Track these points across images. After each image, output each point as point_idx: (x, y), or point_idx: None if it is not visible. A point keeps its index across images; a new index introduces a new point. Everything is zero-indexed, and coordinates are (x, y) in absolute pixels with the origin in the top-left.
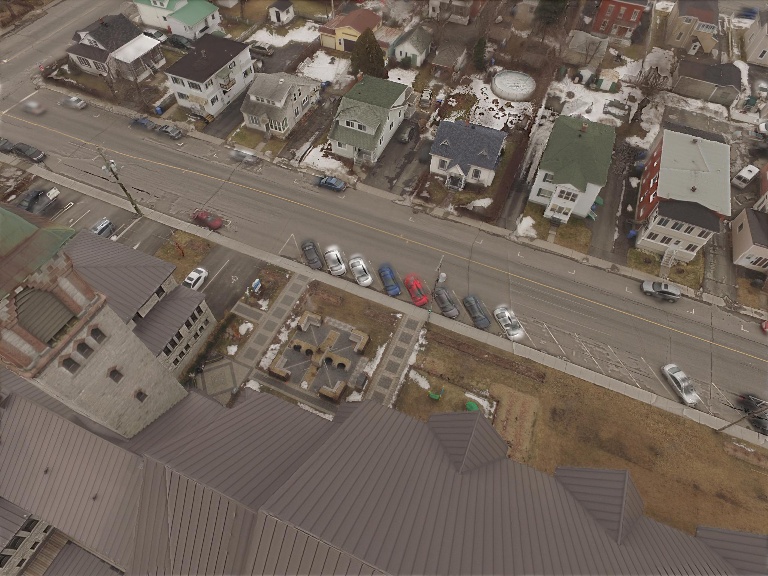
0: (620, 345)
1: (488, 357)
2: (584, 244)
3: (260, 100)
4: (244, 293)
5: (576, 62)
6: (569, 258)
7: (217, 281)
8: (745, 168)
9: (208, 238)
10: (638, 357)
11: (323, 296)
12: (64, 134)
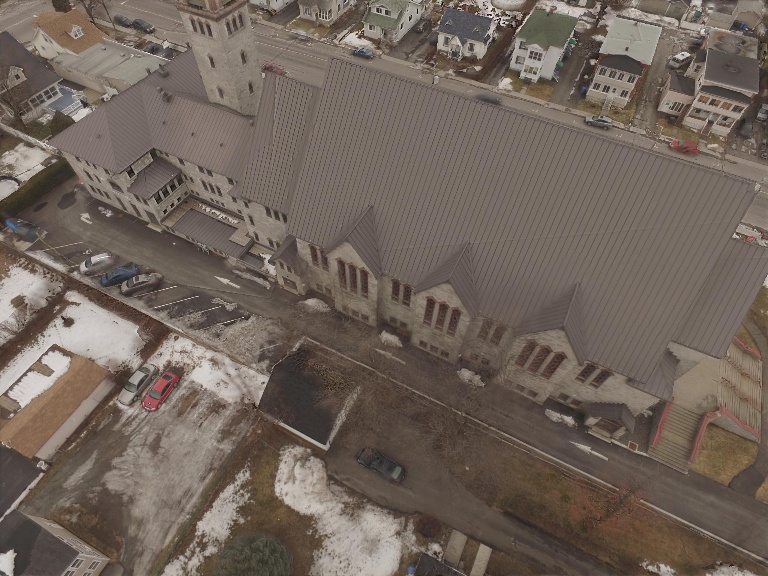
0: None
1: None
2: (547, 95)
3: None
4: None
5: None
6: (535, 103)
7: None
8: (680, 53)
9: None
10: None
11: None
12: (167, 18)
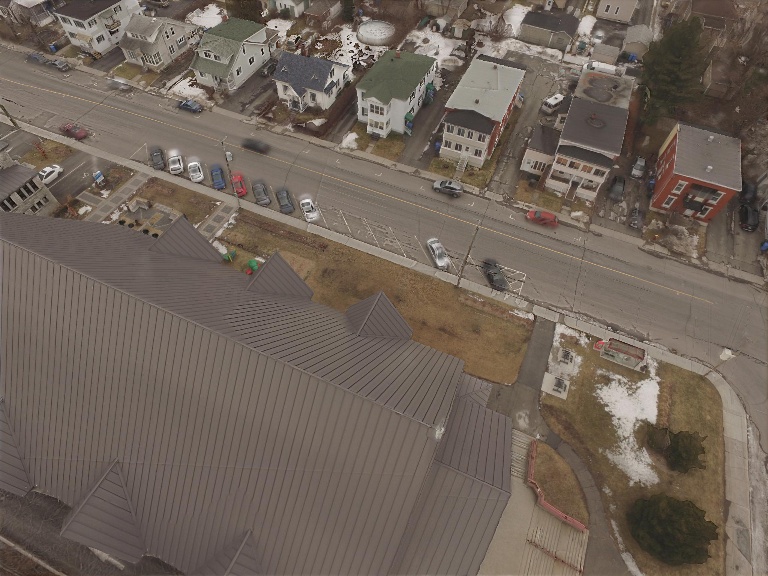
0: (400, 227)
1: (283, 233)
2: (395, 154)
3: (135, 36)
4: (91, 185)
5: (436, 14)
6: (380, 164)
7: (70, 176)
8: (553, 96)
9: (72, 145)
10: (412, 235)
11: (157, 188)
12: None
